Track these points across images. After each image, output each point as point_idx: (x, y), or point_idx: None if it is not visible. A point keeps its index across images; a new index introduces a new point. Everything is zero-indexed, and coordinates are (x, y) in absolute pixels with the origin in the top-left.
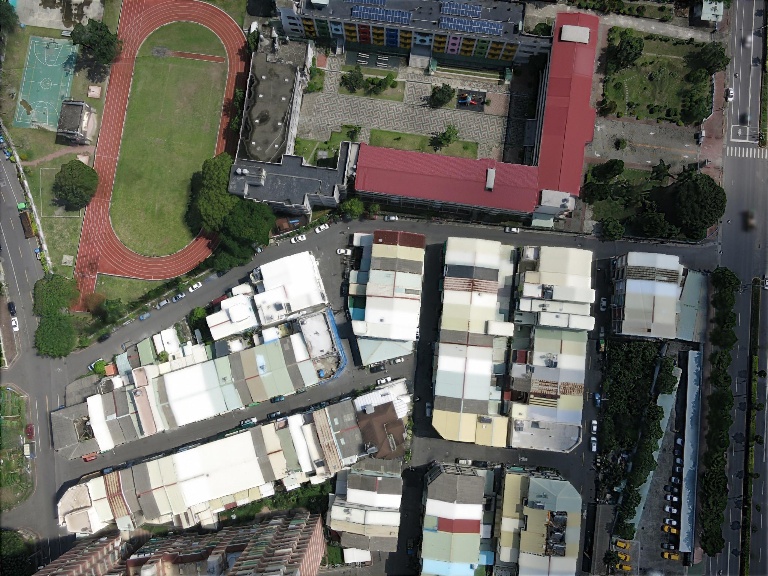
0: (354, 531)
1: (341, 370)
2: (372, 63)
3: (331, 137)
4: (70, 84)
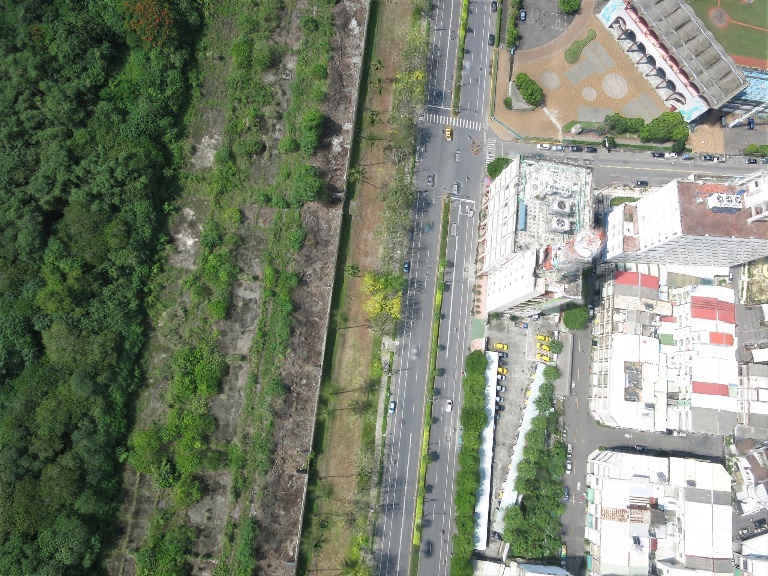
0: None
1: None
2: None
3: None
4: None
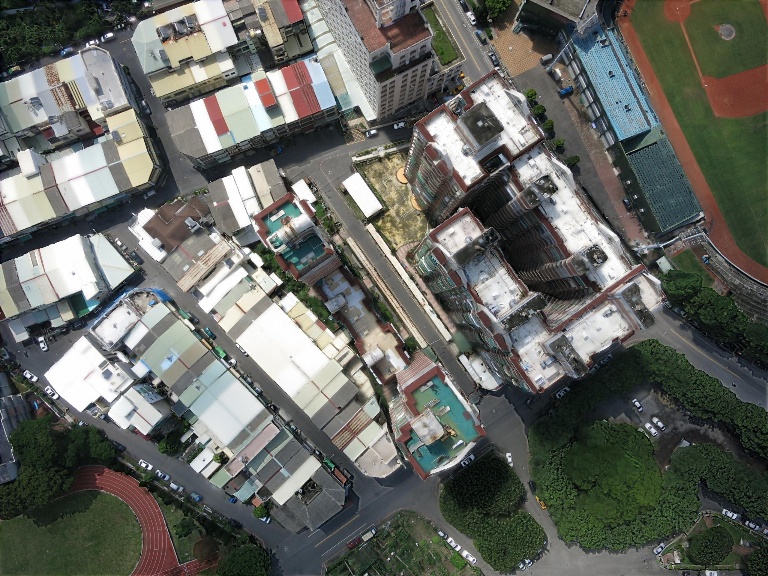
0: None
1: None
2: None
3: None
4: None
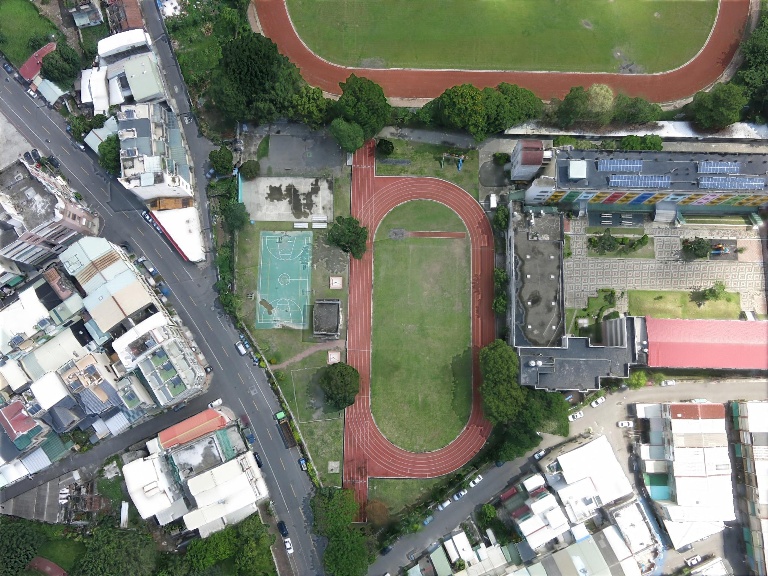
0: None
1: None
2: (616, 222)
3: (589, 303)
4: (309, 277)
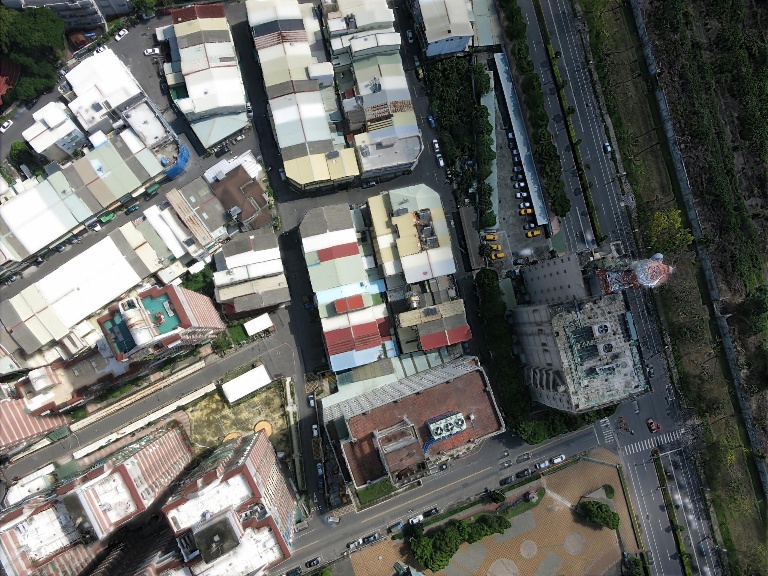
0: (244, 293)
1: (186, 161)
2: None
3: None
4: None
